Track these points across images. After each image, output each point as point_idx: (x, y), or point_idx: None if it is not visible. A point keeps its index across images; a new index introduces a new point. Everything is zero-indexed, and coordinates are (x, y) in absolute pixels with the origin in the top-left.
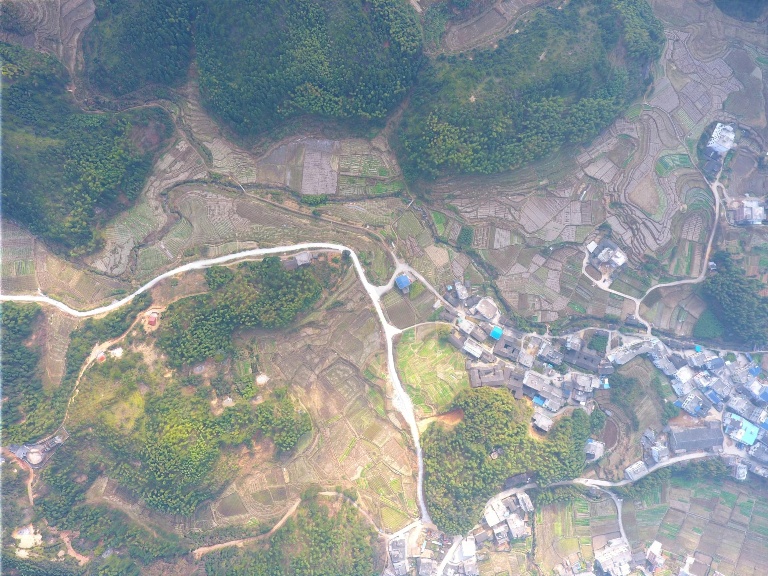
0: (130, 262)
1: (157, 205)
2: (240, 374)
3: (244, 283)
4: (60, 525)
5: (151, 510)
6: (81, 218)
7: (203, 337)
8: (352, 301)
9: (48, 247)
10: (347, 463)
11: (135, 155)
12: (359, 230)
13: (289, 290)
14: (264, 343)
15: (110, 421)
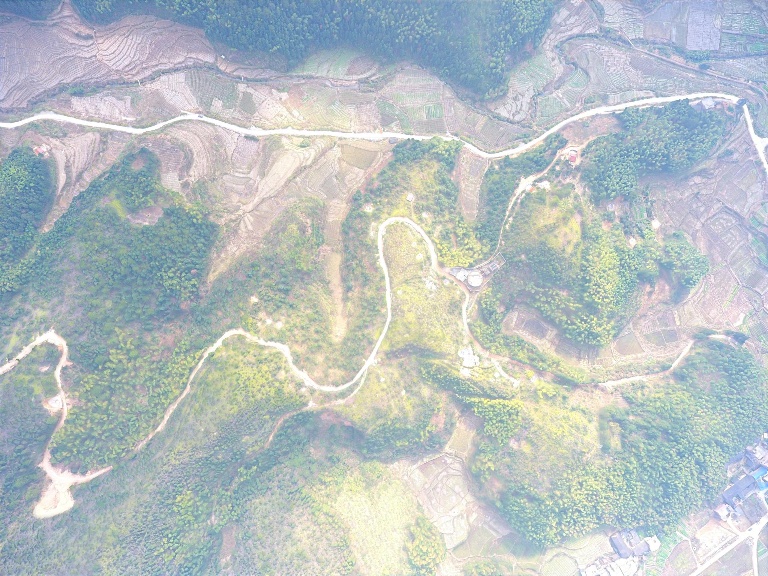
0: (530, 109)
1: (553, 56)
2: (636, 218)
3: (665, 121)
4: (495, 348)
5: (557, 345)
6: (503, 59)
7: (624, 172)
8: (738, 152)
9: (454, 93)
10: (730, 310)
11: (550, 2)
12: (742, 85)
13: (702, 130)
14: (655, 190)
15: (553, 244)
